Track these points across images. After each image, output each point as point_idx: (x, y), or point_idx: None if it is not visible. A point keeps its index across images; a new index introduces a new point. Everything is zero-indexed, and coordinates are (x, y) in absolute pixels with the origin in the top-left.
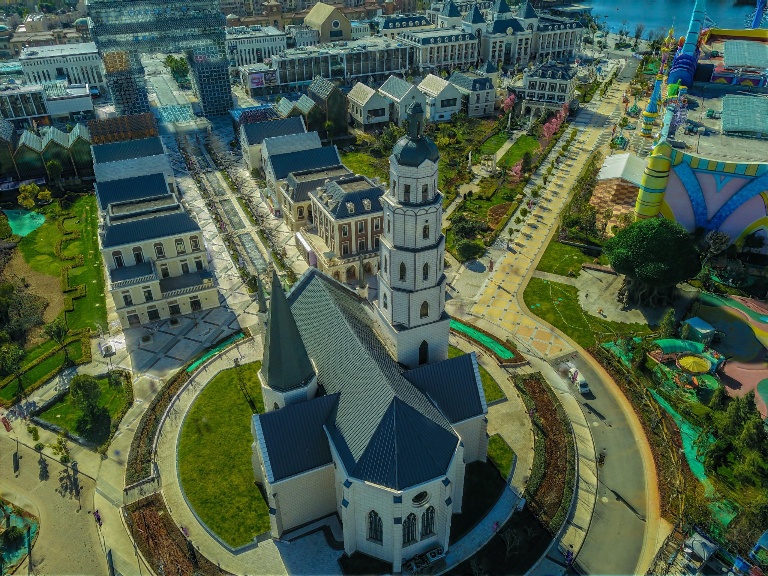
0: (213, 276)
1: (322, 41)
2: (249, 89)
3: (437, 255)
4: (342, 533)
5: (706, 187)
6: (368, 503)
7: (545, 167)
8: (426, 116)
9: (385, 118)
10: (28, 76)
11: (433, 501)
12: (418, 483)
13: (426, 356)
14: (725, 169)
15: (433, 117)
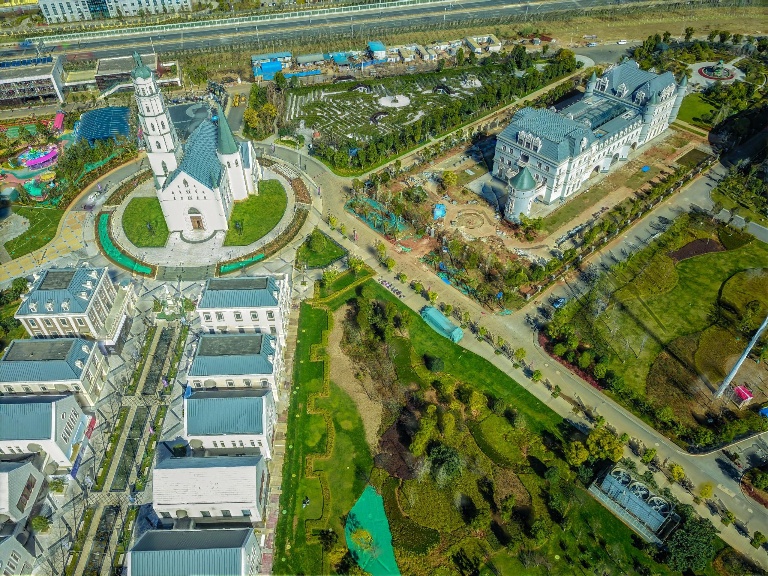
0: None
1: None
2: None
3: None
4: None
5: None
6: None
7: None
8: None
9: None
10: None
11: None
12: None
13: None
14: None
15: None
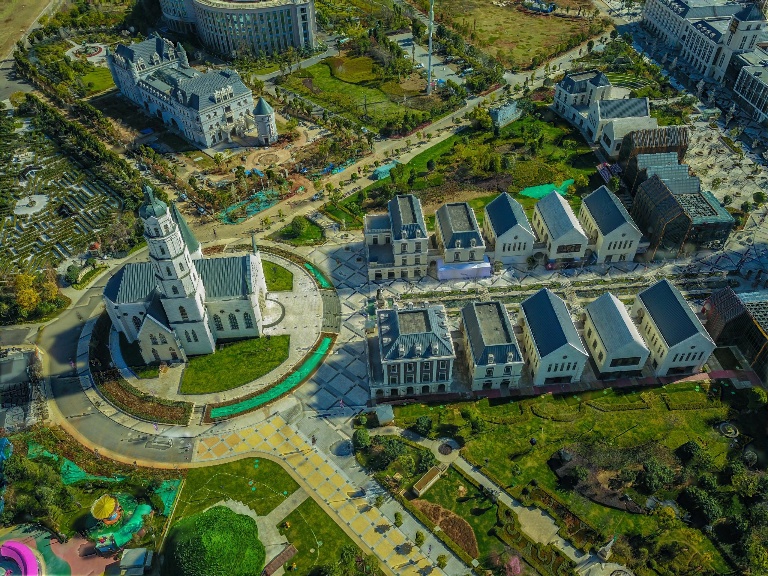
0: None
1: None
2: None
3: None
4: None
5: None
6: None
7: None
8: None
9: None
10: None
11: None
12: None
13: None
14: None
15: None
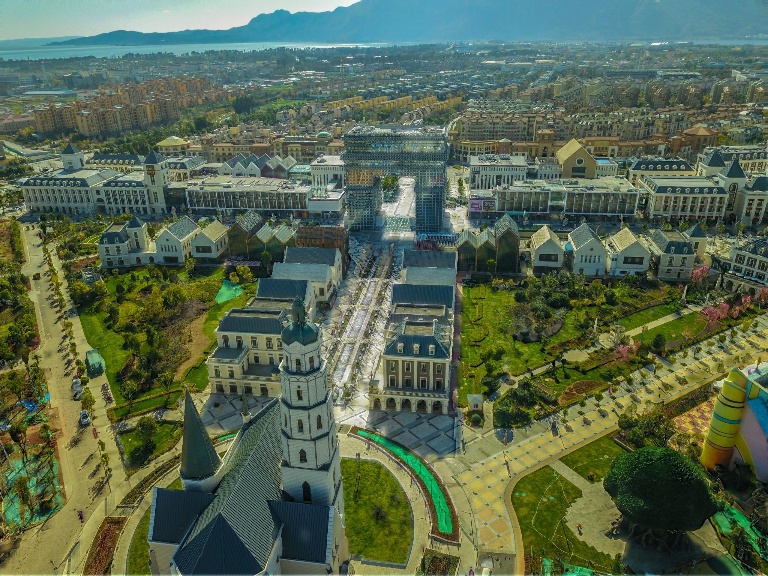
0: None
1: (563, 175)
2: (468, 212)
3: (309, 416)
4: None
5: None
6: None
7: None
8: (607, 269)
9: (558, 264)
10: (314, 177)
11: None
12: None
13: (310, 495)
14: None
15: (614, 271)
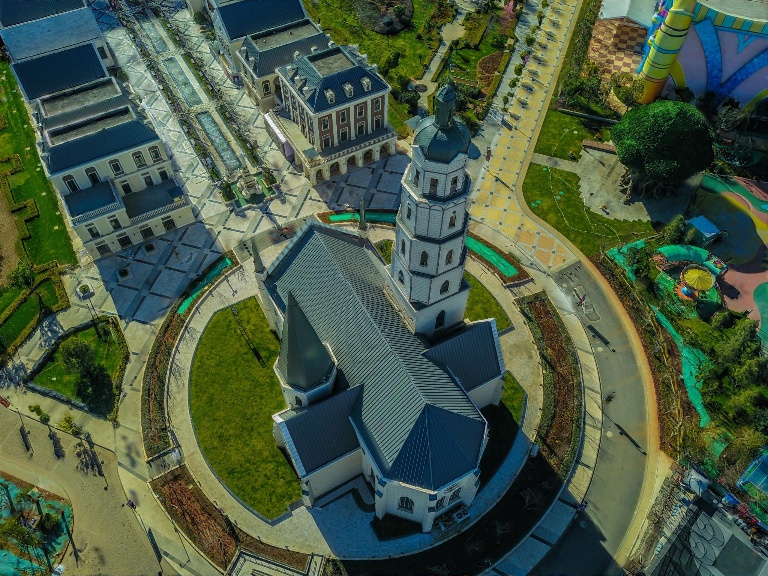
0: (179, 180)
1: None
2: None
3: (462, 240)
4: (370, 495)
5: (726, 47)
6: (402, 493)
7: None
8: None
9: None
10: None
11: (463, 484)
12: (452, 480)
13: (443, 321)
14: (752, 28)
15: None
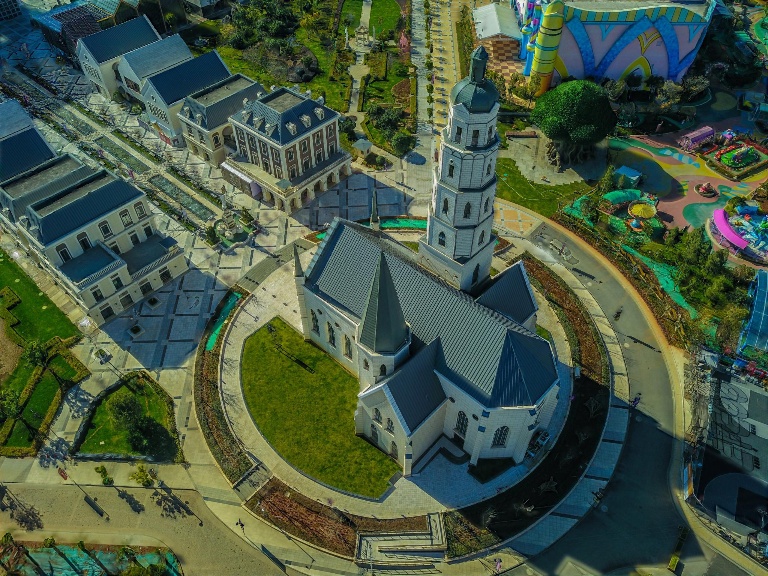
0: None
1: None
2: None
3: None
4: (458, 449)
5: (593, 37)
6: (501, 422)
7: (417, 30)
8: None
9: None
10: None
11: (546, 401)
12: (543, 393)
13: (477, 276)
14: (610, 18)
15: None
